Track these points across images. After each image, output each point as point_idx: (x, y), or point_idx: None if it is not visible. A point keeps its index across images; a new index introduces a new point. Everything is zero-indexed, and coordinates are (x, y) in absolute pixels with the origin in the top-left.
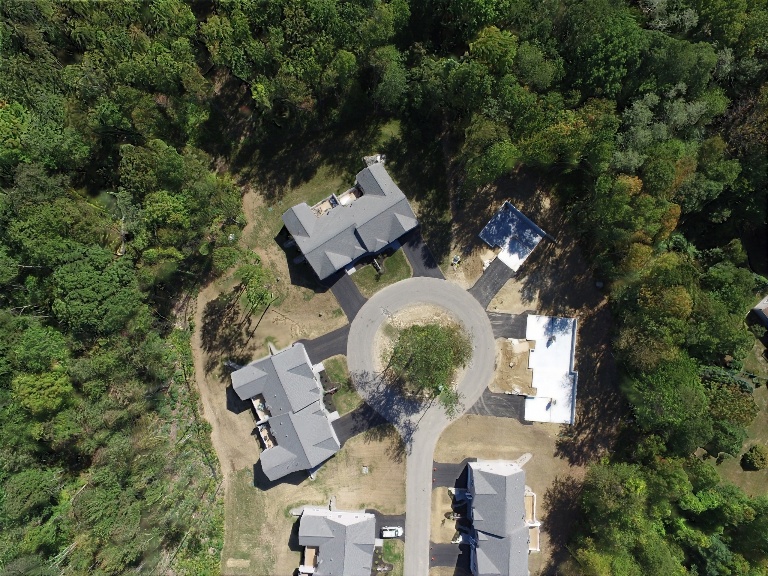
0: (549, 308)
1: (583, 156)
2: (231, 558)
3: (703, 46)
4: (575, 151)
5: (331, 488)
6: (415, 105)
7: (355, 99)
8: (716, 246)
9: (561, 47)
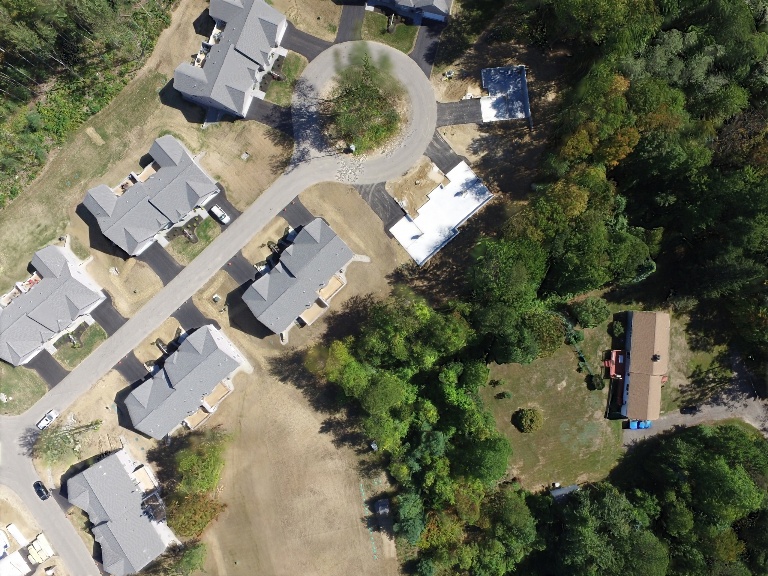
0: (482, 171)
1: (605, 36)
2: (94, 128)
3: (763, 34)
4: (602, 21)
5: (209, 146)
6: None
7: None
8: None
9: None
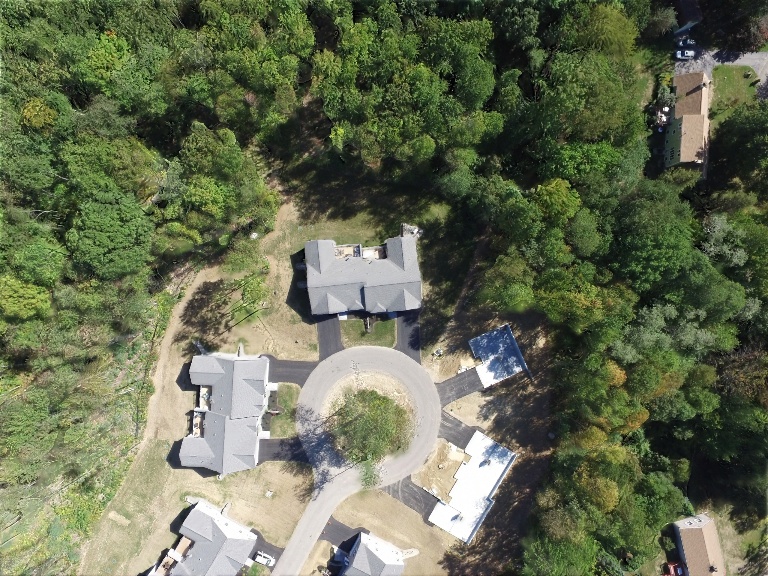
0: (498, 433)
1: (588, 329)
2: (115, 511)
3: (738, 288)
4: (583, 323)
5: (231, 495)
6: (470, 203)
7: (420, 172)
8: (667, 455)
9: (616, 226)
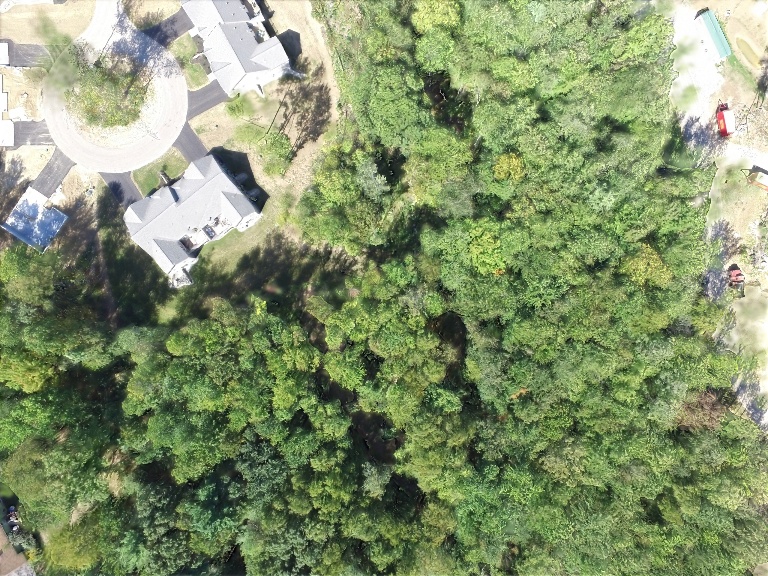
0: None
1: None
2: None
3: None
4: None
5: None
6: None
7: None
8: None
9: None
